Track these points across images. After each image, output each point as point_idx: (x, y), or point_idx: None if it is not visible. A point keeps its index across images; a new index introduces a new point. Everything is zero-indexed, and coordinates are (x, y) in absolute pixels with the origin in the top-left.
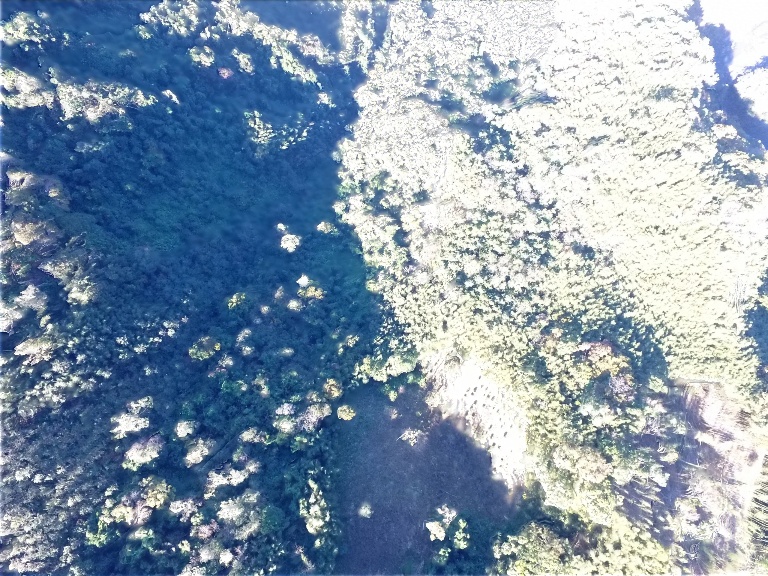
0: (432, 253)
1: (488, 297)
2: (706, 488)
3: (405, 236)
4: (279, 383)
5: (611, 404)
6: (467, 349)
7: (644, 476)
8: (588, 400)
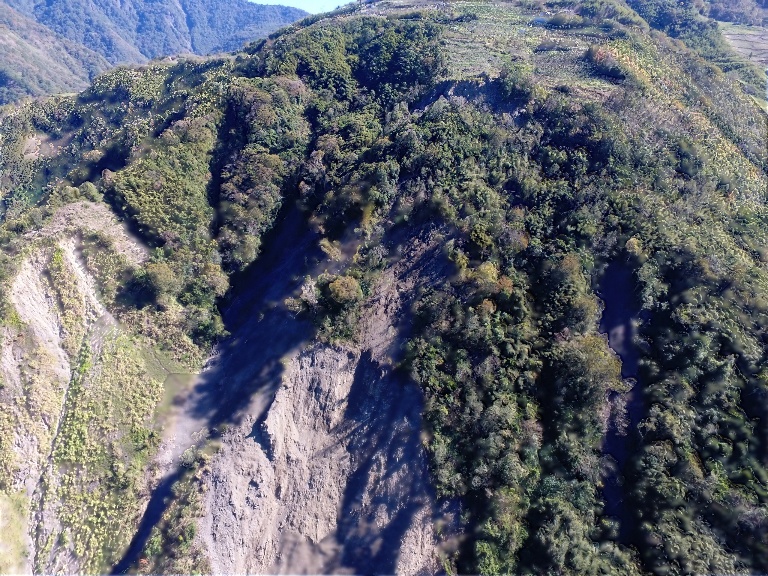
0: (4, 178)
1: (1, 160)
2: (0, 118)
3: (7, 197)
4: (74, 161)
5: (0, 129)
6: (20, 154)
7: (8, 118)
8: (4, 131)
